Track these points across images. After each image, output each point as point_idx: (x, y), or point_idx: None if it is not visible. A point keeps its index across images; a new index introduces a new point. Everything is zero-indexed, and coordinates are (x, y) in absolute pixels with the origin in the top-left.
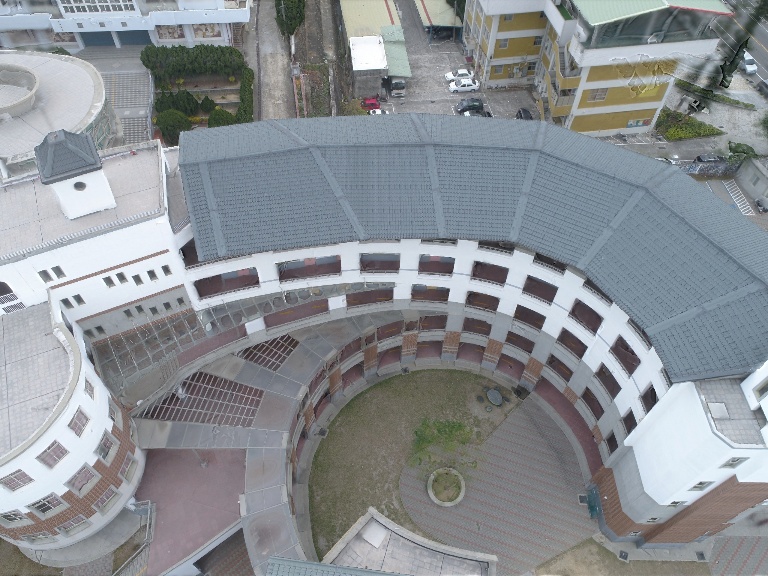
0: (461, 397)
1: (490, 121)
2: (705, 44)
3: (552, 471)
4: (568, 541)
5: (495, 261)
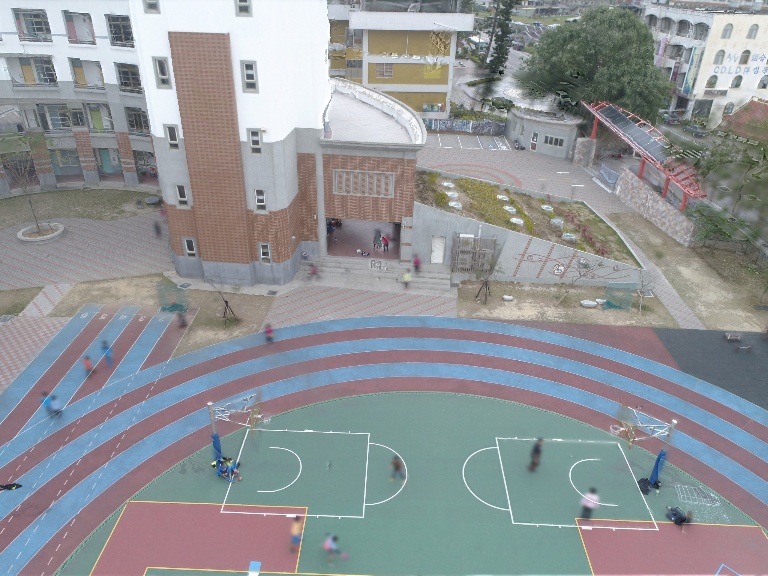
0: (122, 201)
1: None
2: (461, 18)
3: (164, 238)
4: (133, 272)
5: (118, 10)
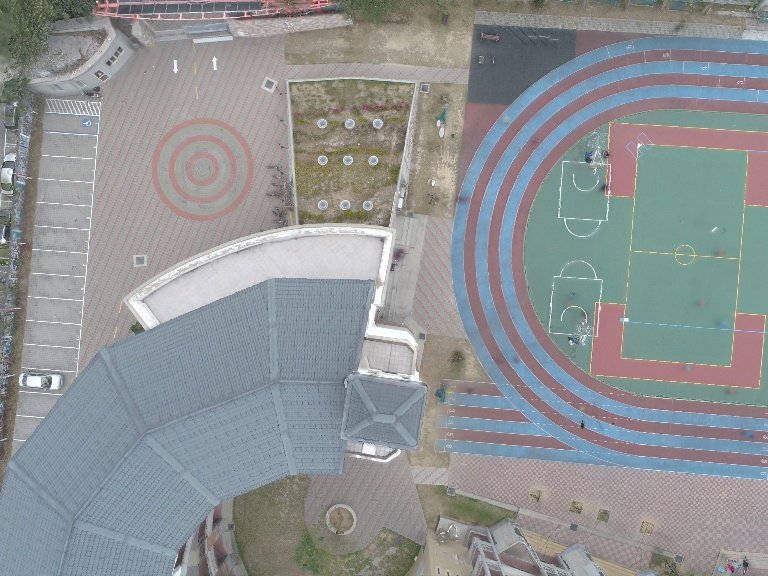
0: None
1: (3, 528)
2: None
3: None
4: None
5: None
